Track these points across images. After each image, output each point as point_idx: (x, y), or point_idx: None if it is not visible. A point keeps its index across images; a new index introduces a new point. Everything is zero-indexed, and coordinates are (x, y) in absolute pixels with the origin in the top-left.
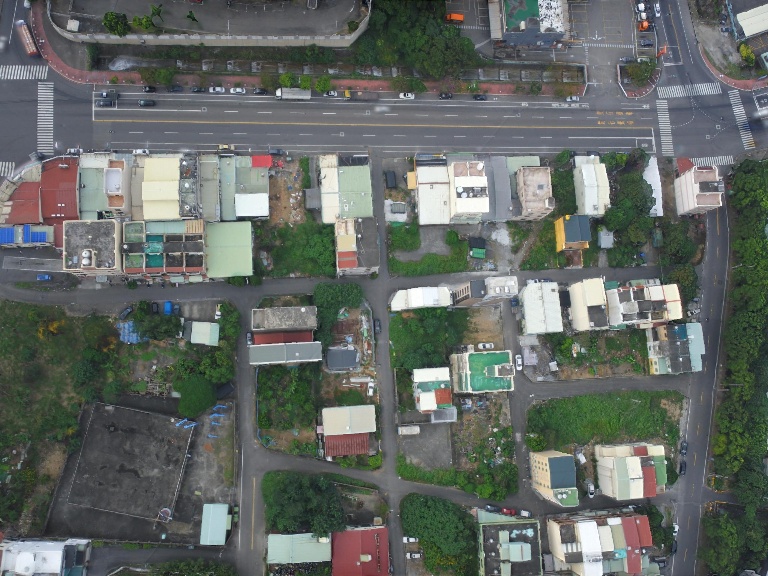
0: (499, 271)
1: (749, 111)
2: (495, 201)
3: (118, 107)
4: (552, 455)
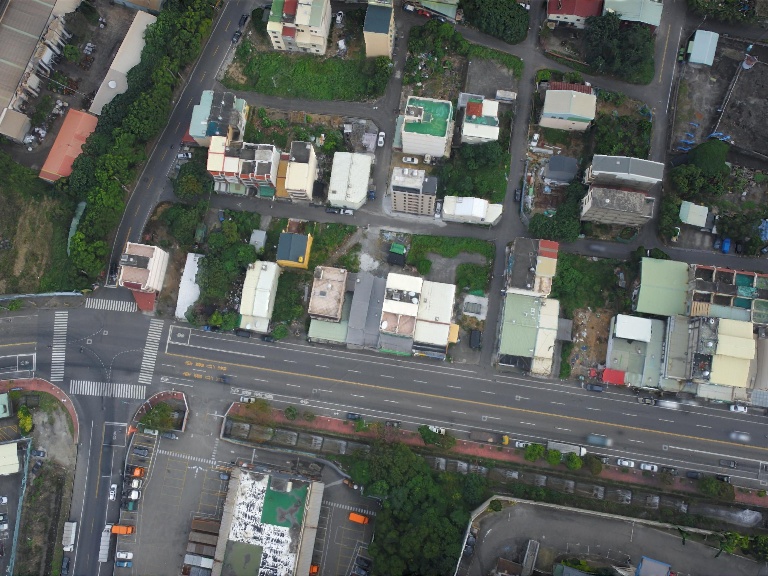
0: (379, 229)
1: (47, 354)
2: (372, 293)
3: (759, 464)
4: (381, 39)
